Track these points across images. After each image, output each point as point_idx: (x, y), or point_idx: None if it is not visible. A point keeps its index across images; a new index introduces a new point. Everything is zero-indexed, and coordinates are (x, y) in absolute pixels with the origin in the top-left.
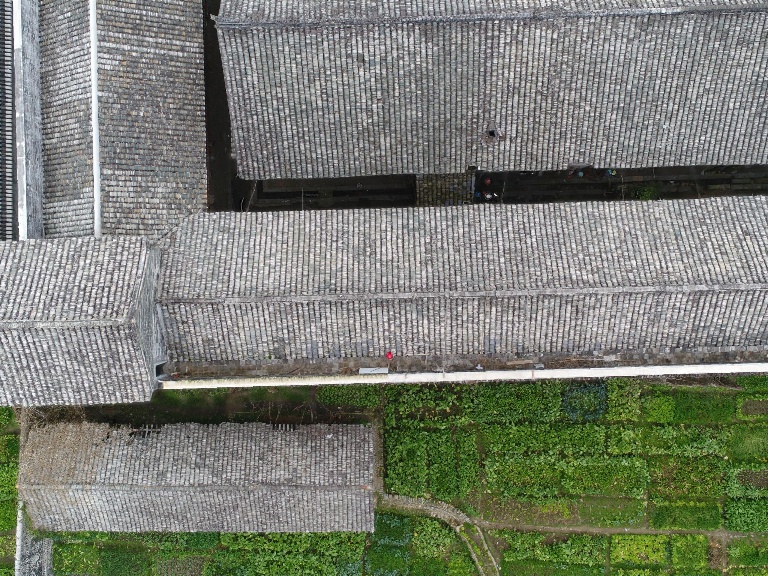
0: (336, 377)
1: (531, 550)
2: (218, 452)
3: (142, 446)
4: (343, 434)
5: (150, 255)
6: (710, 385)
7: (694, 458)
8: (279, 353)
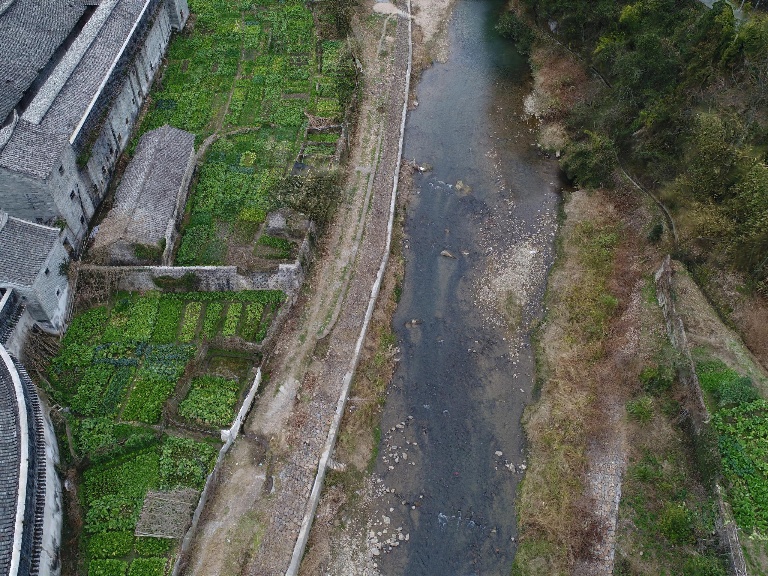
0: None
1: None
2: None
3: None
4: None
5: None
6: None
7: None
8: None
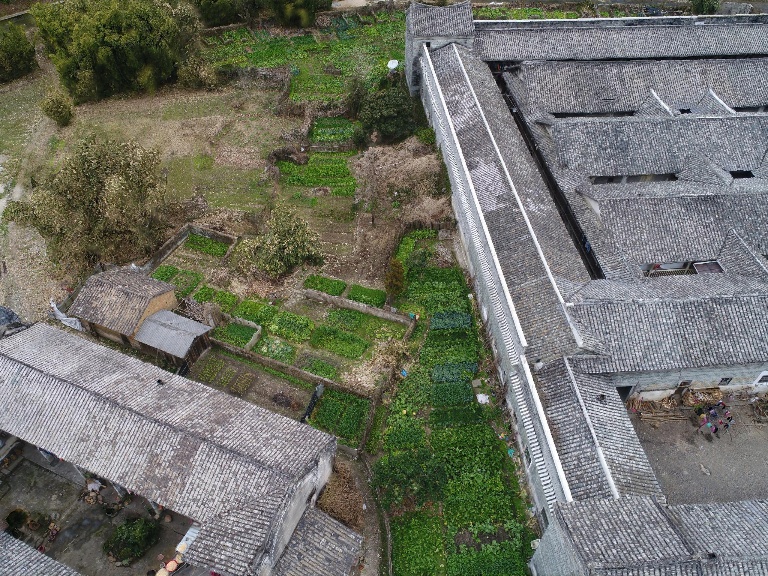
0: (714, 16)
1: None
2: None
3: None
4: None
5: None
6: None
7: None
8: None
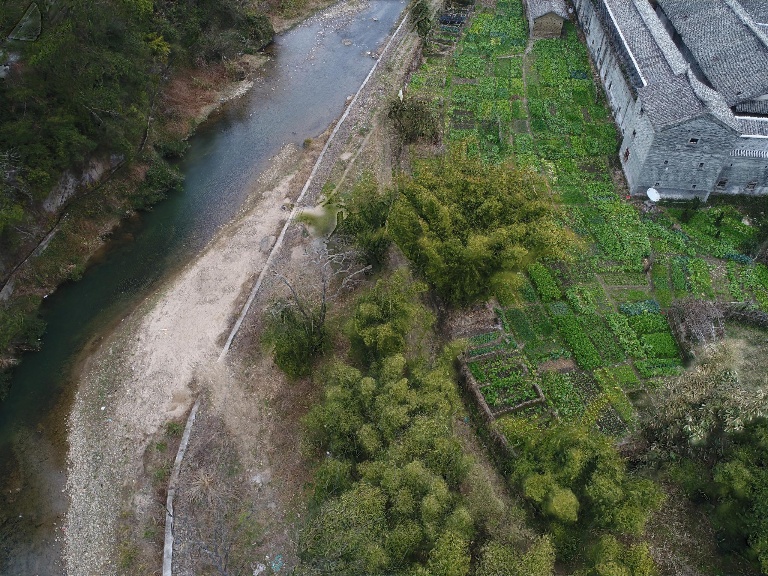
0: None
1: None
2: None
3: None
4: None
5: None
6: None
7: None
8: None
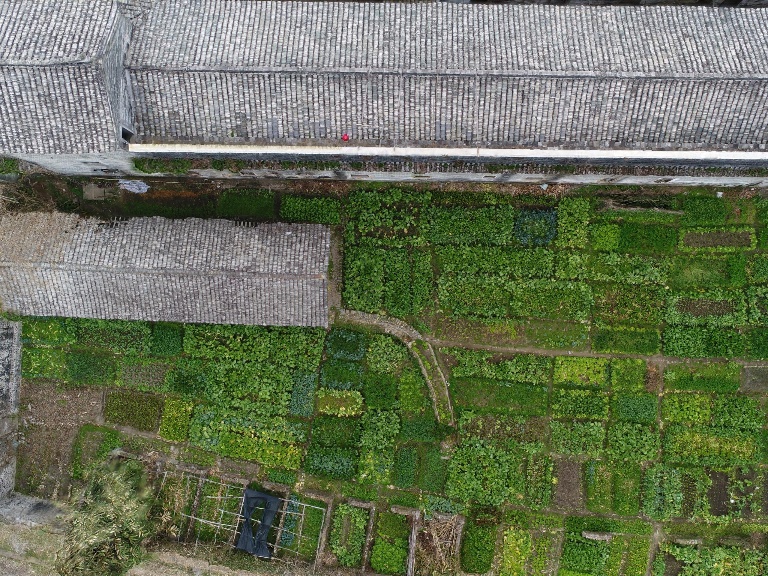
0: (293, 146)
1: (478, 367)
2: (182, 242)
3: (109, 234)
4: (302, 232)
5: (121, 19)
6: (653, 209)
7: (637, 286)
8: (241, 131)
